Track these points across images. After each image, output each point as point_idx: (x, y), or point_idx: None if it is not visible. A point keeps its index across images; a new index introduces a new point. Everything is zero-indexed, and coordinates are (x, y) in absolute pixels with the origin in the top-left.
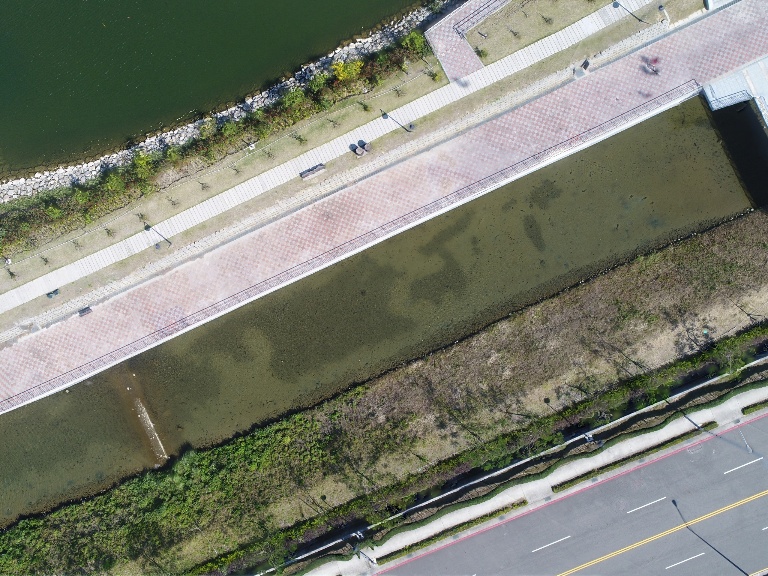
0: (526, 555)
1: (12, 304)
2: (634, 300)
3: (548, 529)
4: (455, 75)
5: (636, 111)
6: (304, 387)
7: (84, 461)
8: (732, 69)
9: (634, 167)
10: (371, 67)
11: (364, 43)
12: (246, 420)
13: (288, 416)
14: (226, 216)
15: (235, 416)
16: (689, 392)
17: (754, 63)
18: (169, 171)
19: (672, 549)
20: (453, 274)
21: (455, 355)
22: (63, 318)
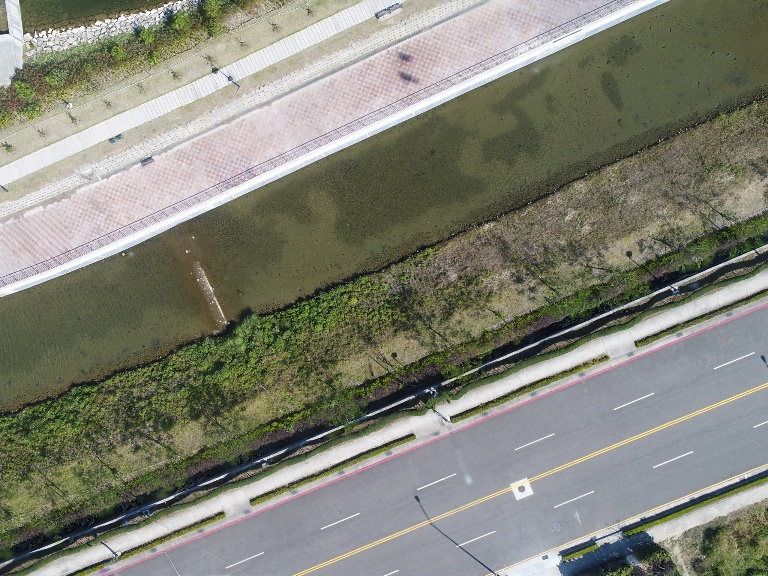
0: (607, 413)
1: (73, 150)
2: (718, 154)
3: (630, 386)
4: None
5: None
6: (370, 250)
7: (140, 327)
8: None
9: (716, 22)
10: None
11: None
12: (309, 285)
13: (354, 279)
14: (297, 58)
15: (298, 280)
16: None
17: None
18: (237, 14)
19: (760, 407)
20: (527, 133)
21: (529, 214)
22: (124, 168)
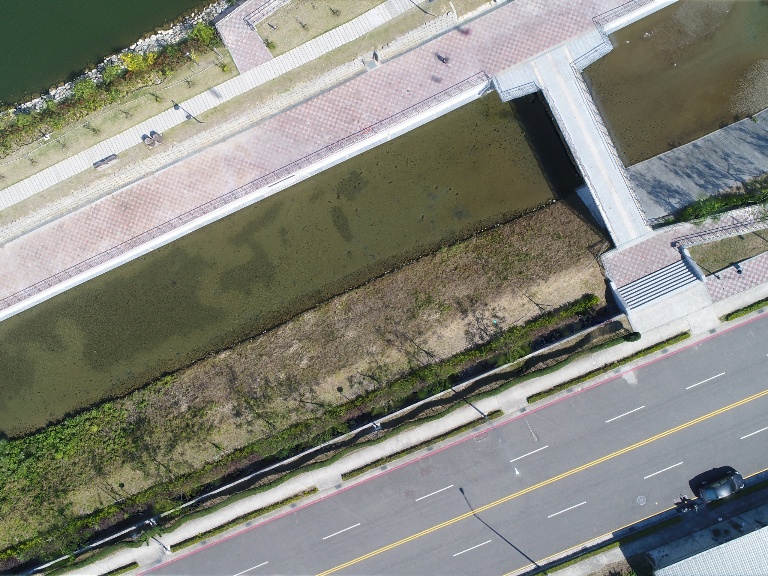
0: (317, 542)
1: None
2: (432, 290)
3: (338, 517)
4: (245, 66)
5: (427, 102)
6: (116, 377)
7: None
8: (520, 61)
9: (439, 159)
10: (163, 58)
11: (165, 35)
12: (59, 409)
13: (98, 405)
14: (21, 206)
15: (49, 405)
16: (475, 381)
17: (542, 55)
18: None
19: (459, 536)
20: (262, 265)
21: (260, 345)
22: None
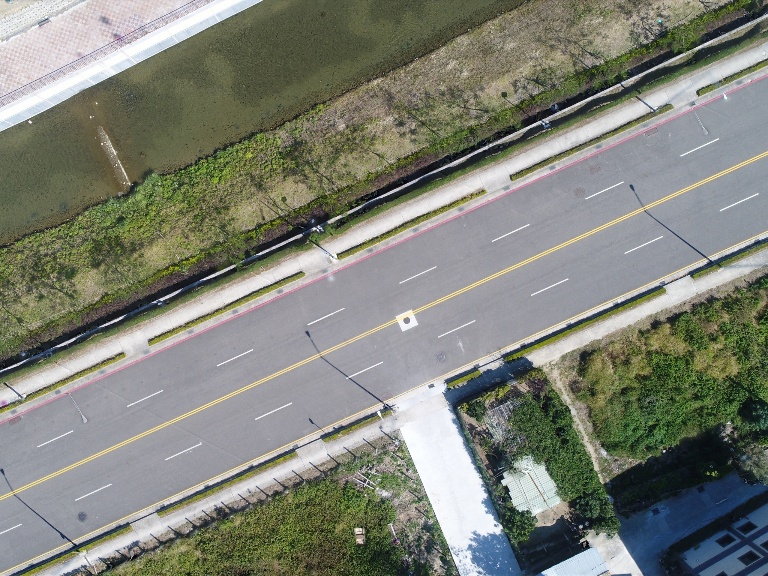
0: (486, 245)
1: None
2: (590, 1)
3: (507, 218)
4: None
5: None
6: (266, 110)
7: (48, 192)
8: None
9: None
10: None
11: None
12: (209, 145)
13: (250, 137)
14: None
15: (198, 142)
16: (644, 75)
17: None
18: None
19: (631, 234)
20: None
21: (414, 68)
22: (23, 30)
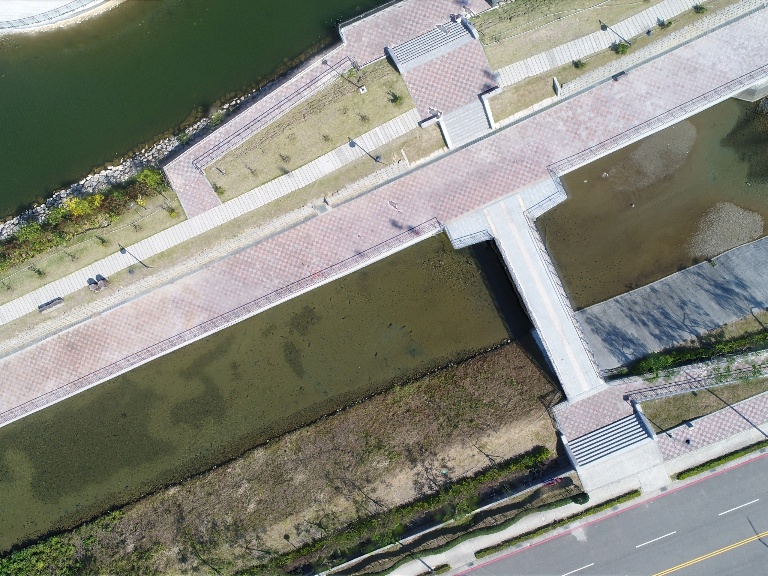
0: None
1: None
2: (382, 434)
3: None
4: (193, 211)
5: (378, 248)
6: (65, 509)
7: None
8: (473, 208)
9: (393, 295)
10: (110, 201)
11: (115, 171)
12: (7, 540)
13: (46, 539)
14: None
15: None
16: (422, 534)
17: (495, 203)
18: None
19: None
20: (213, 399)
21: (210, 482)
22: None
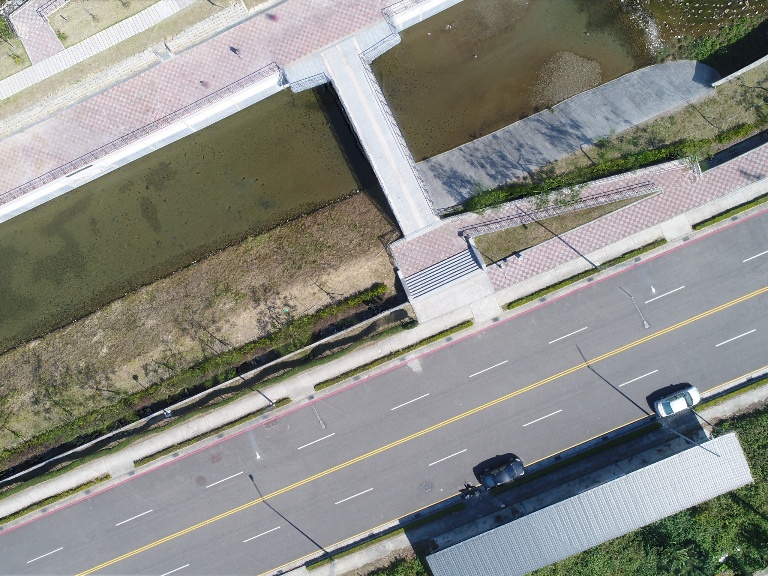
0: (110, 529)
1: None
2: (231, 279)
3: (131, 503)
4: (37, 57)
5: (220, 93)
6: None
7: None
8: (311, 52)
9: (246, 149)
10: None
11: None
12: None
13: None
14: None
15: None
16: (263, 369)
17: (332, 46)
18: None
19: (249, 523)
20: (73, 254)
21: (68, 334)
22: None
